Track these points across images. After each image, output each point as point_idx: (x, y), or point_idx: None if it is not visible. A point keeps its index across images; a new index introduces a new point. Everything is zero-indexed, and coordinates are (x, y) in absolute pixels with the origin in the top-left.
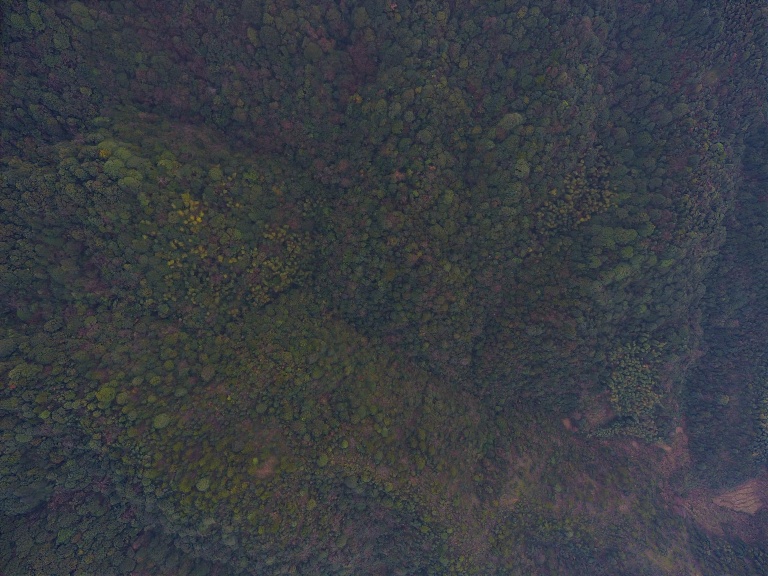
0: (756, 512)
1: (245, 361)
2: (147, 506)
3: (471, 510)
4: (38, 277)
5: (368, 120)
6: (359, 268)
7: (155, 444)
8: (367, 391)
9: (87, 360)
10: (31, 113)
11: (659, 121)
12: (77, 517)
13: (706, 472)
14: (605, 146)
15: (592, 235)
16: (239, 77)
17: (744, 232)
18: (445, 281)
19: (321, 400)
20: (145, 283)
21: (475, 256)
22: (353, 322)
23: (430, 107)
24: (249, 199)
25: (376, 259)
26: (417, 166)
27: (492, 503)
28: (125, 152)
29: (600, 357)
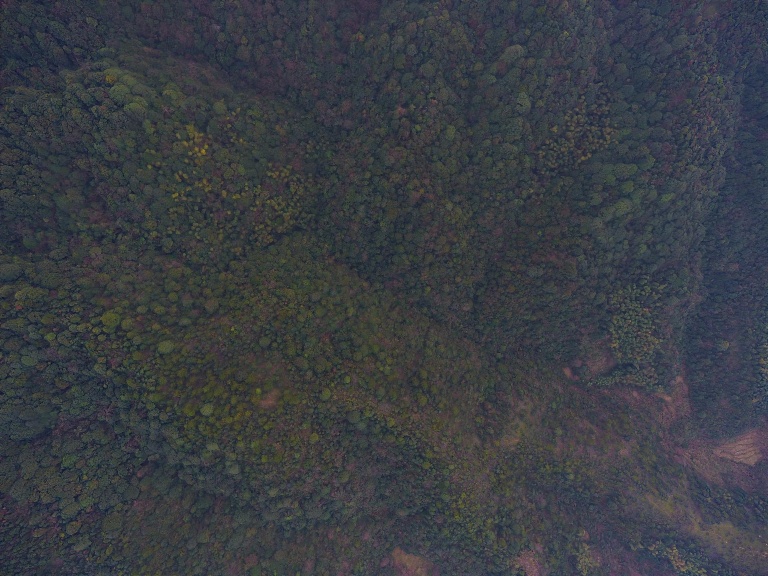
0: (756, 463)
1: (248, 295)
2: (151, 431)
3: (472, 449)
4: (44, 204)
5: (371, 57)
6: (361, 207)
7: (159, 369)
8: (369, 332)
9: (92, 287)
10: (38, 41)
11: (659, 54)
12: (82, 444)
13: (706, 420)
14: (605, 83)
15: (593, 173)
16: (243, 13)
17: (743, 172)
18: (447, 220)
19: (324, 338)
20: (150, 215)
21: (477, 197)
22: (355, 267)
23: (432, 40)
24: (253, 136)
25: (378, 197)
26: (419, 100)
27: (493, 443)
28: (131, 79)
29: (601, 298)
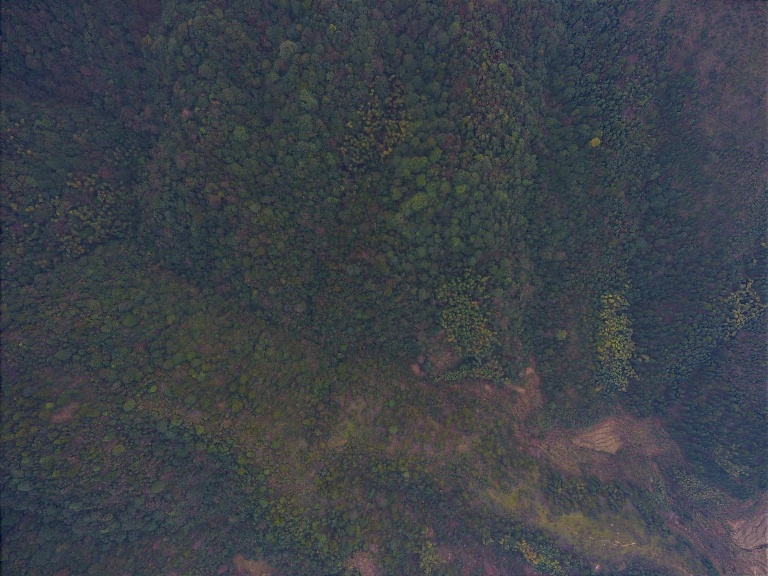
0: (617, 451)
1: (43, 308)
2: None
3: (296, 453)
4: None
5: (158, 60)
6: (166, 213)
7: None
8: (189, 339)
9: None
10: None
11: (439, 43)
12: None
13: (556, 411)
14: (398, 75)
15: (395, 167)
16: (20, 21)
17: (553, 159)
18: (254, 222)
19: (136, 348)
20: None
21: (289, 197)
22: (183, 273)
23: (205, 40)
24: (44, 146)
25: (179, 202)
26: (201, 102)
27: (319, 445)
28: None
29: (421, 294)
